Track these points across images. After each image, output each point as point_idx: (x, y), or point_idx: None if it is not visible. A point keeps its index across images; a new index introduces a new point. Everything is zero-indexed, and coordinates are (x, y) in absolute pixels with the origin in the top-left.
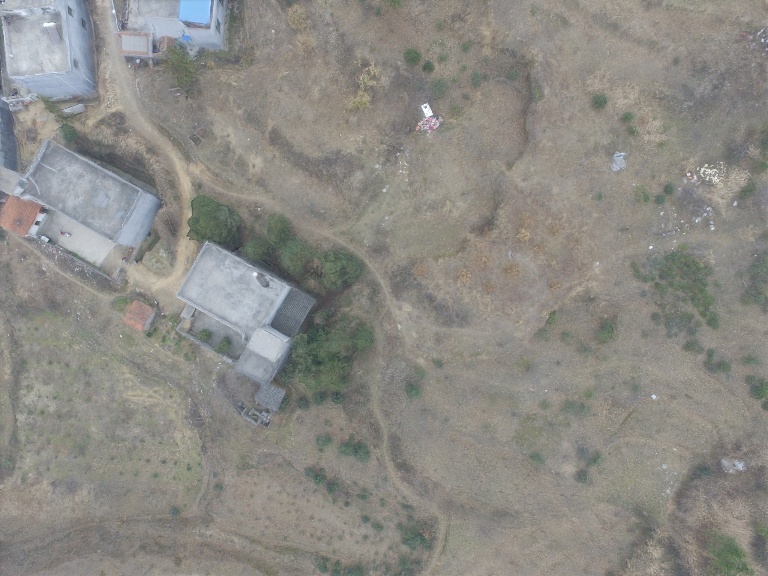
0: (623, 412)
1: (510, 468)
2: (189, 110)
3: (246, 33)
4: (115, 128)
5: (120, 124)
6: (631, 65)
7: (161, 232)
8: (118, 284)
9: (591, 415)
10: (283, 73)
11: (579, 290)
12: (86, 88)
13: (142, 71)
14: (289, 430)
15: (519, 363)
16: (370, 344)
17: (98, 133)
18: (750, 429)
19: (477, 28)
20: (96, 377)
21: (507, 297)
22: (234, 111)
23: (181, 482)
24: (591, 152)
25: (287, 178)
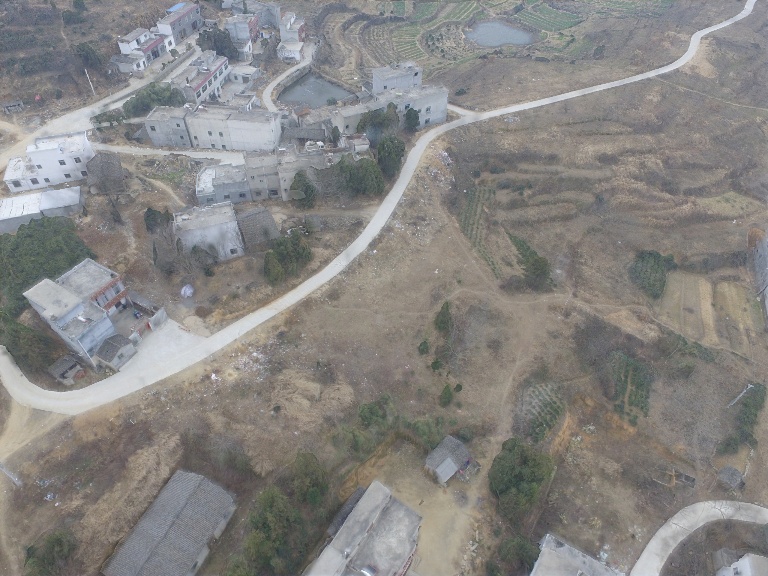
0: None
1: None
2: None
3: None
4: None
5: None
6: None
7: None
8: None
9: None
10: None
11: None
12: None
13: None
14: None
15: None
16: None
17: None
18: None
19: None
20: None
21: None
22: None
23: None
24: None
25: None
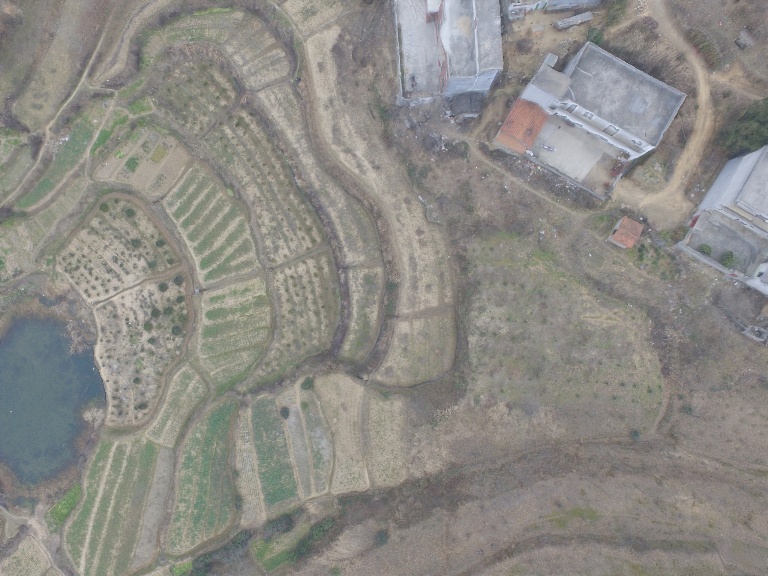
0: None
1: None
2: (738, 12)
3: None
4: (649, 32)
5: (654, 28)
6: None
7: (669, 143)
8: (601, 200)
9: None
10: None
11: None
12: None
13: None
14: None
15: None
16: None
17: (627, 38)
18: None
19: None
20: (552, 298)
21: None
22: None
23: (638, 405)
24: None
25: None
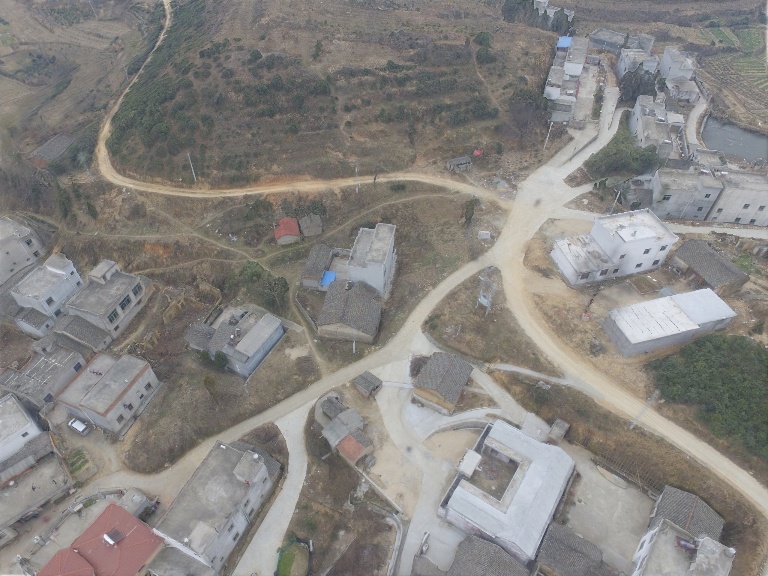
0: None
1: None
2: None
3: None
4: None
5: None
6: None
7: None
8: None
9: None
10: (530, 31)
11: None
12: None
13: None
14: None
15: None
16: None
17: None
18: None
19: None
20: None
21: (454, 6)
22: None
23: None
24: None
25: None
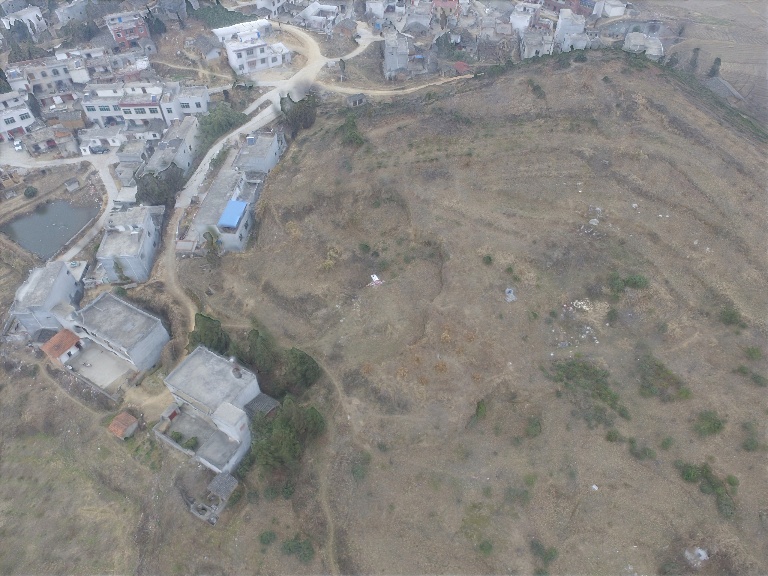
0: (570, 504)
1: (464, 569)
2: (210, 277)
3: (258, 242)
4: (155, 289)
5: (159, 287)
6: (505, 244)
7: (165, 357)
8: (115, 401)
9: (539, 508)
10: (277, 251)
11: (499, 382)
12: (143, 274)
13: (184, 260)
14: (235, 529)
15: (459, 451)
16: (322, 429)
17: (141, 293)
18: (701, 516)
19: (404, 231)
20: (59, 491)
21: (439, 388)
22: (240, 274)
23: None
24: (488, 289)
25: (270, 313)
